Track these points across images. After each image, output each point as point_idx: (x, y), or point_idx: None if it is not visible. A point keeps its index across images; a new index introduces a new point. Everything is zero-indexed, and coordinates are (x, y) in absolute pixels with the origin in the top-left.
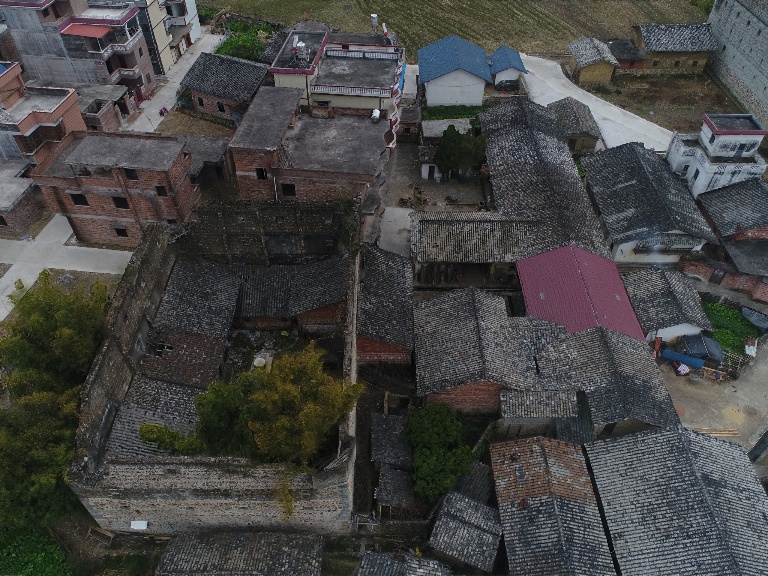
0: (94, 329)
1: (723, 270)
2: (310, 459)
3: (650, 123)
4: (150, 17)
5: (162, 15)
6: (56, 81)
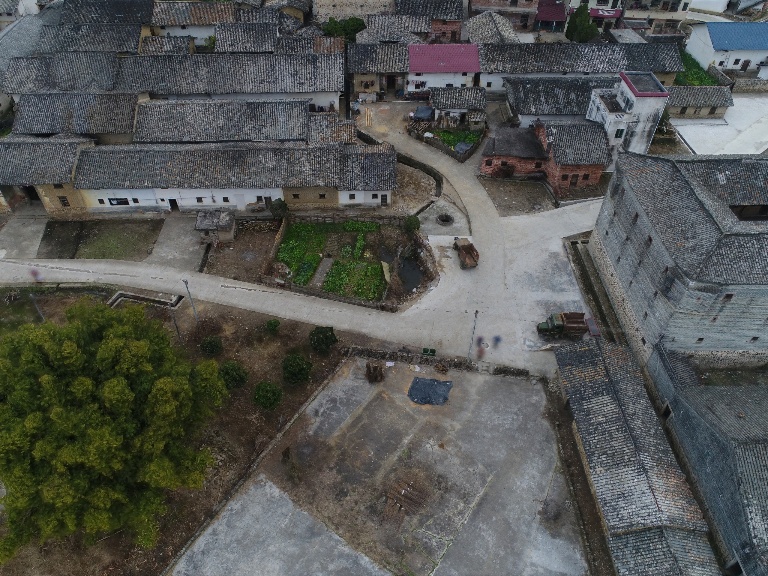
0: None
1: None
2: None
3: None
4: None
5: None
6: None
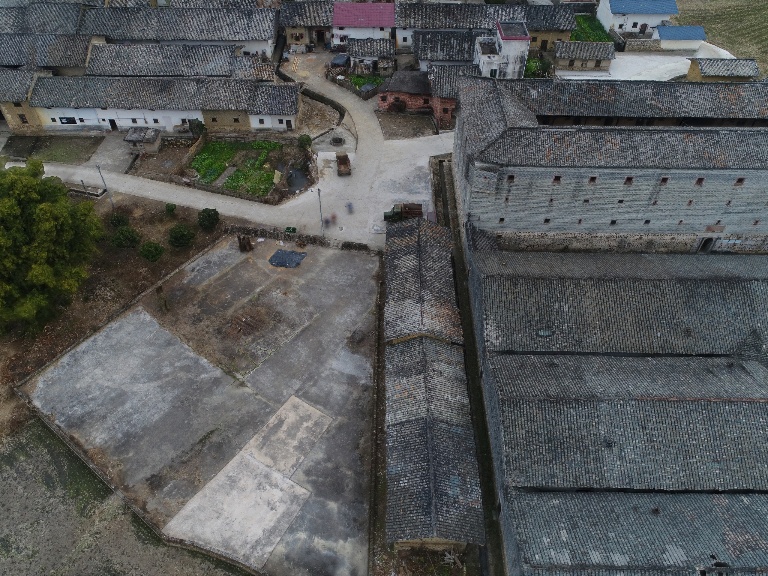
0: None
1: None
2: None
3: None
4: None
5: None
6: None
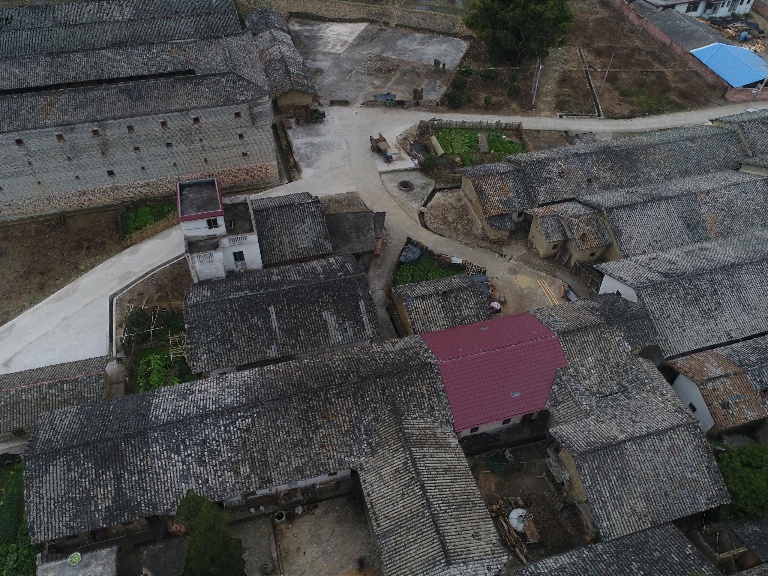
0: None
1: None
2: None
3: (30, 312)
4: None
5: None
6: None
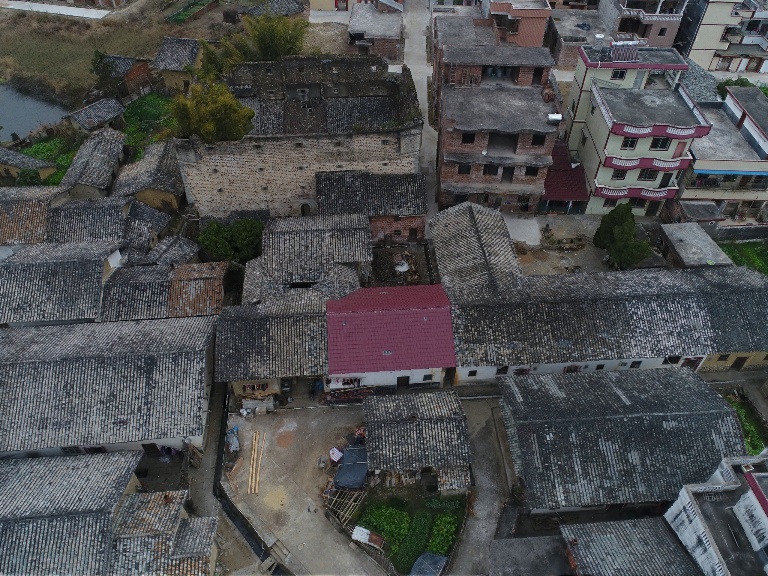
0: (270, 46)
1: (497, 524)
2: (185, 135)
3: None
4: (708, 13)
5: (730, 21)
6: (601, 18)
